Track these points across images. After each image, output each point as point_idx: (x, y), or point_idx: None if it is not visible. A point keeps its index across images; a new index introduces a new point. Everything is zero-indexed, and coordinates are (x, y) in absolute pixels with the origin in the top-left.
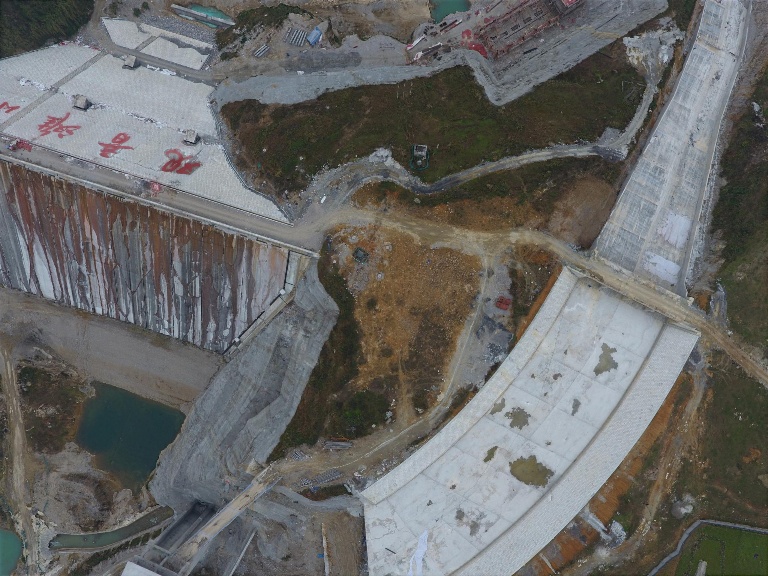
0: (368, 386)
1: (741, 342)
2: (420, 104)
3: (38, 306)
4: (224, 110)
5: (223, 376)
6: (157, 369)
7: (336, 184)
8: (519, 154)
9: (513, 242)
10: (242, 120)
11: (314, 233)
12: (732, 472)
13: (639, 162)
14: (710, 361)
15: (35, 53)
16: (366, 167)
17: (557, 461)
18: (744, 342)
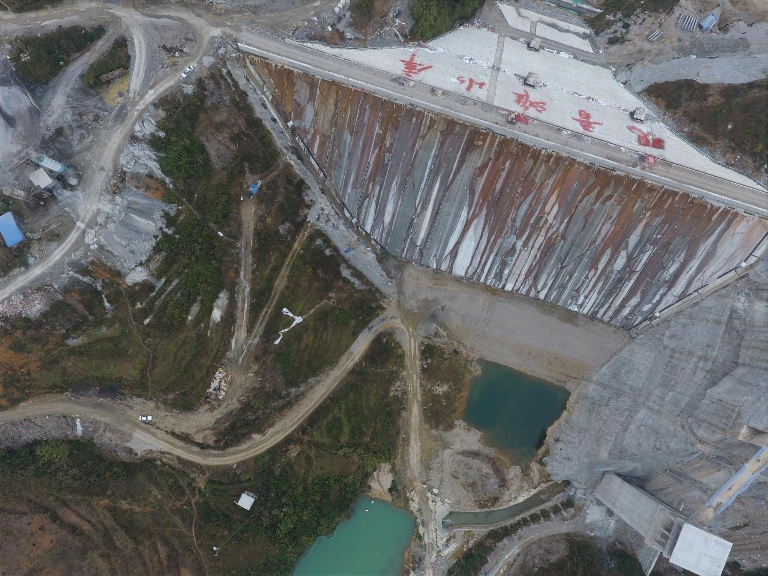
0: None
1: None
2: None
3: (447, 283)
4: (654, 90)
5: (646, 350)
6: (556, 345)
7: None
8: None
9: None
10: (684, 99)
11: None
12: None
13: None
14: None
15: (453, 34)
16: None
17: None
18: None
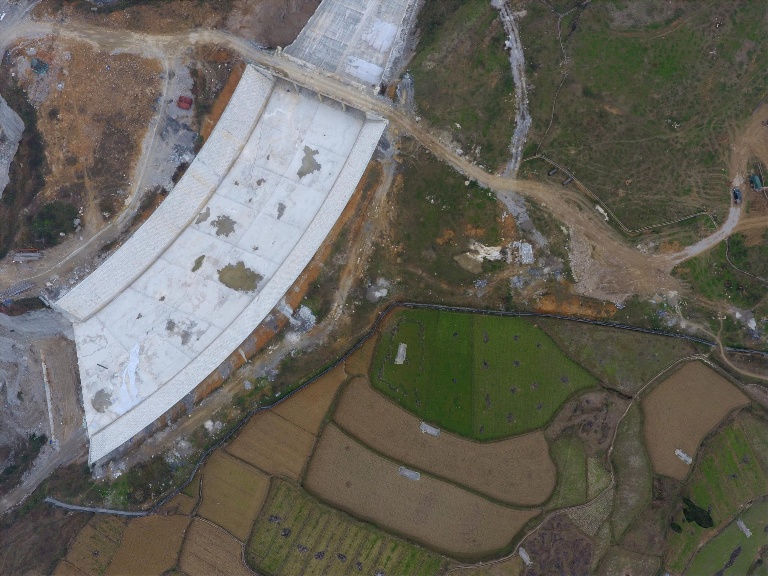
0: (56, 196)
1: (430, 127)
2: None
3: None
4: None
5: None
6: None
7: (16, 1)
8: None
9: (193, 43)
10: None
11: None
12: (428, 255)
13: None
14: (399, 148)
15: None
16: None
17: (265, 265)
18: (433, 127)
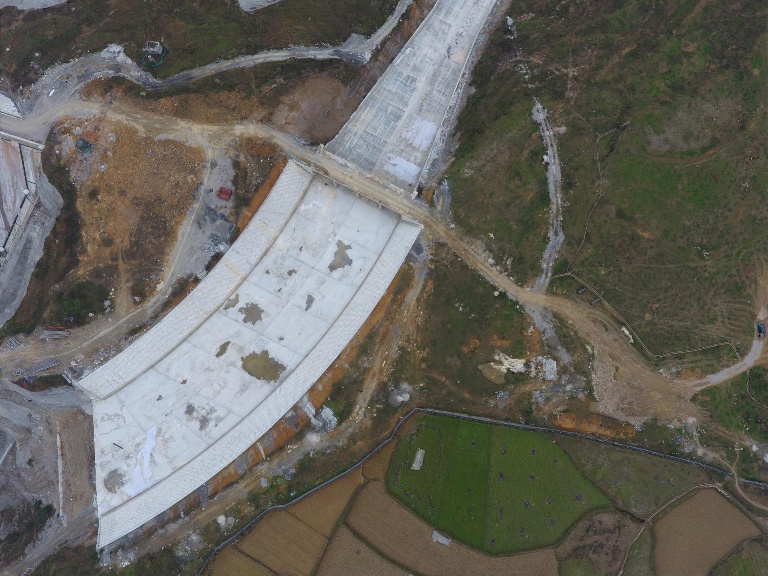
0: (88, 276)
1: (463, 235)
2: (167, 8)
3: None
4: None
5: None
6: None
7: (66, 78)
8: (255, 53)
9: (237, 135)
10: None
11: (41, 125)
12: (452, 362)
13: (387, 69)
14: (432, 253)
15: None
16: (97, 62)
17: (289, 356)
18: (466, 235)
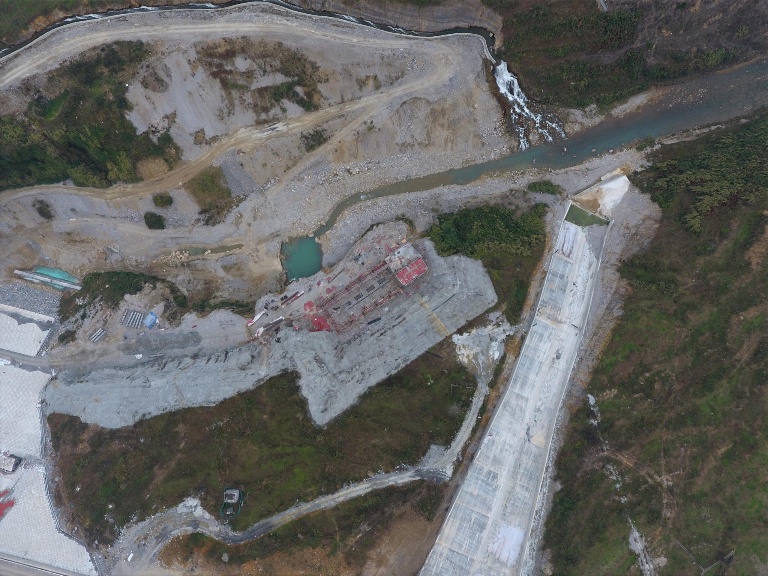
0: None
1: None
2: (238, 431)
3: None
4: (49, 422)
5: None
6: None
7: (143, 539)
8: (335, 492)
9: None
10: (62, 441)
11: None
12: None
13: (469, 473)
14: None
15: None
16: (174, 519)
17: None
18: None
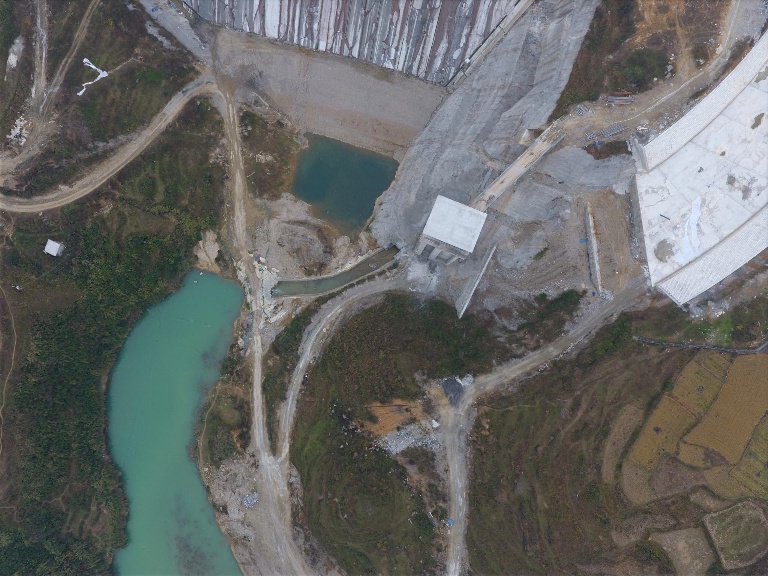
0: (646, 43)
1: None
2: None
3: (261, 45)
4: None
5: (456, 96)
6: (377, 108)
7: None
8: None
9: None
10: None
11: None
12: None
13: None
14: None
15: None
16: None
17: None
18: None
